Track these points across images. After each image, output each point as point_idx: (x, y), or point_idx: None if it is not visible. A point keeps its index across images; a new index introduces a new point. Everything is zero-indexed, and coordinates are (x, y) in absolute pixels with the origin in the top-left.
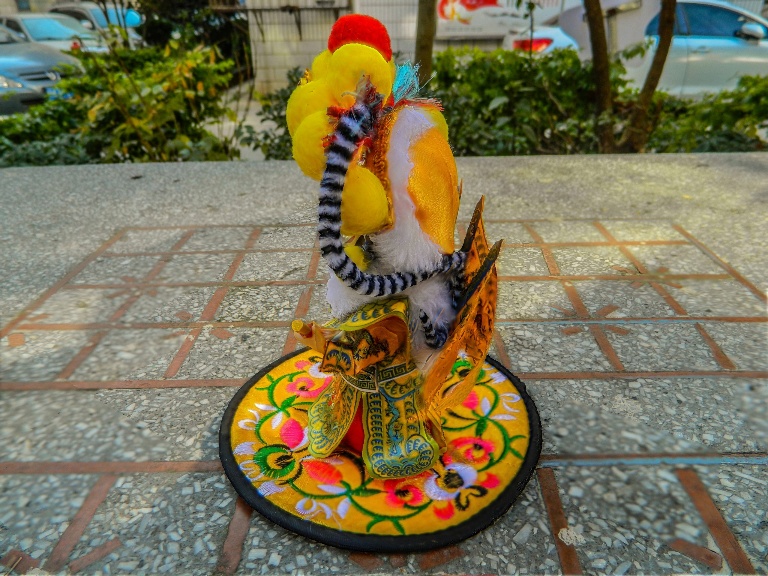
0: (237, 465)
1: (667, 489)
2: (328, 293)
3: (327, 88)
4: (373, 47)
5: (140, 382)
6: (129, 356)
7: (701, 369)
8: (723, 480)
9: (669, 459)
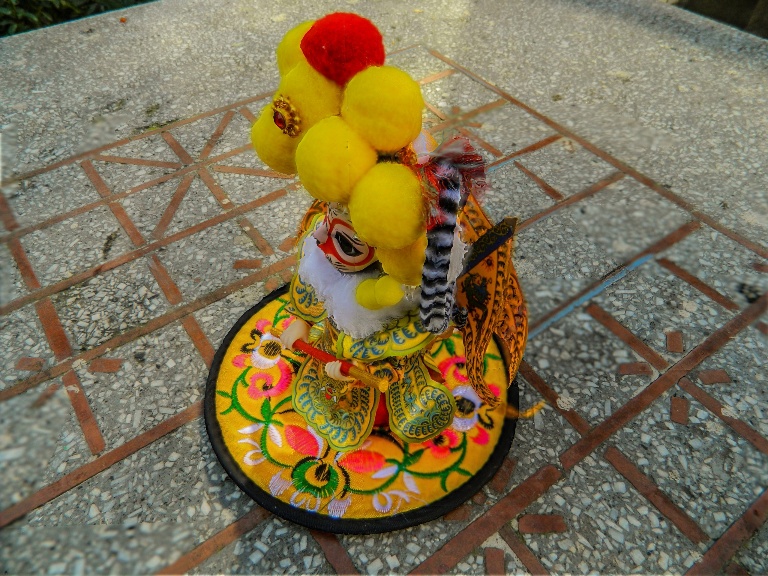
0: (289, 505)
1: (591, 328)
2: (339, 318)
3: (360, 136)
4: (380, 62)
5: (71, 477)
6: (16, 453)
7: (545, 208)
8: (614, 302)
9: (577, 302)
